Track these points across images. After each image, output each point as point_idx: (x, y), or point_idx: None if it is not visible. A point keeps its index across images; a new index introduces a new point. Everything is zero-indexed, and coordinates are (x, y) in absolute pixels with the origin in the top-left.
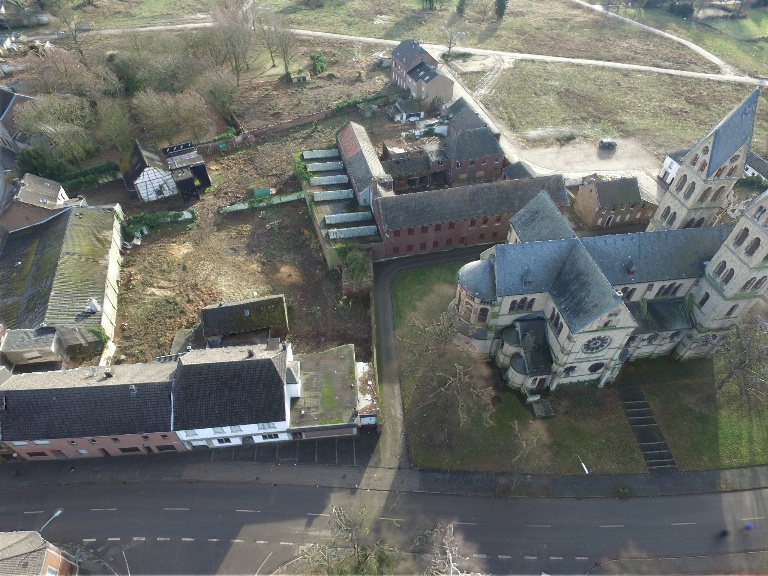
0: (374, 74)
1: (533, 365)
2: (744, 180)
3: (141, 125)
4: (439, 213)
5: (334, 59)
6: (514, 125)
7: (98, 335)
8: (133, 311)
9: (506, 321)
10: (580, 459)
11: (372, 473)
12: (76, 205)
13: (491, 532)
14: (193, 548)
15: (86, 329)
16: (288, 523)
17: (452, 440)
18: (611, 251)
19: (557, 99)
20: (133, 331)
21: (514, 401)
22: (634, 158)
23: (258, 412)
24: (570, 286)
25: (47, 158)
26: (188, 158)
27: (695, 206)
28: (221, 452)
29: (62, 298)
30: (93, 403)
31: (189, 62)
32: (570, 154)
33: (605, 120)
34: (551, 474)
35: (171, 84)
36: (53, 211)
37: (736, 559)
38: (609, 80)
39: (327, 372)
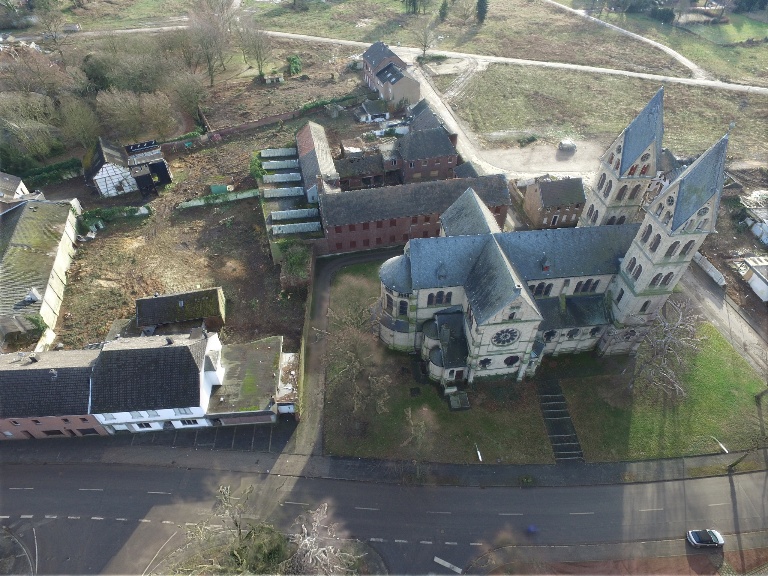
0: (347, 76)
1: (449, 357)
2: None
3: (106, 123)
4: (380, 210)
5: (310, 61)
6: (478, 126)
7: (36, 323)
8: (78, 301)
9: (427, 314)
10: (477, 447)
11: (285, 459)
12: (32, 199)
13: (391, 517)
14: (101, 527)
15: (23, 317)
16: (196, 505)
17: (366, 429)
18: (525, 247)
19: (525, 101)
20: (75, 320)
21: (433, 393)
22: (592, 160)
23: (173, 397)
24: (481, 280)
25: (11, 154)
26: (148, 155)
27: (614, 204)
28: (142, 437)
29: (4, 287)
30: (14, 386)
31: (158, 62)
32: (529, 155)
33: (569, 122)
34: (459, 463)
35: (139, 84)
36: (9, 204)
37: (628, 548)
38: (579, 83)
39: (252, 362)
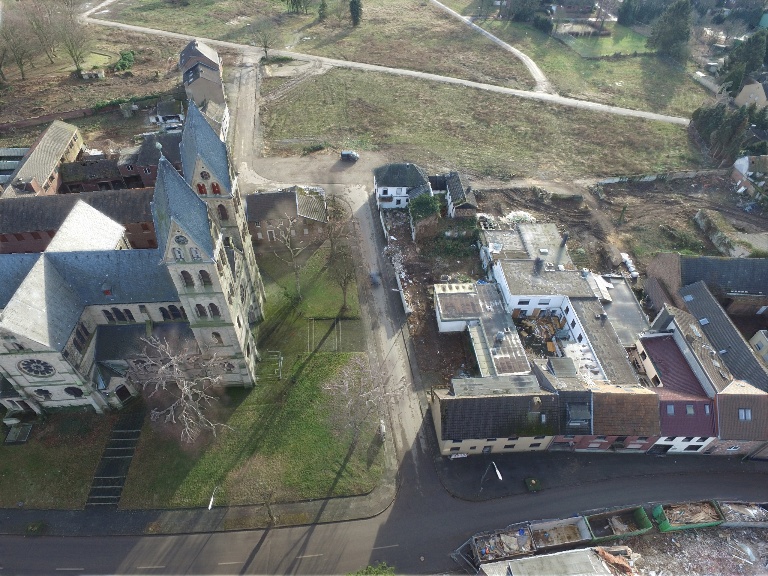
0: (174, 74)
1: (1, 386)
2: (421, 200)
3: None
4: (50, 219)
5: (145, 57)
6: (272, 132)
7: None
8: None
9: None
10: None
11: None
12: None
13: None
14: None
15: None
16: None
17: None
18: (84, 268)
19: (341, 108)
20: None
21: None
22: (367, 172)
23: None
24: None
25: None
26: None
27: None
28: None
29: None
30: None
31: None
32: (304, 165)
33: (371, 132)
34: None
35: None
36: None
37: None
38: (411, 91)
39: None
